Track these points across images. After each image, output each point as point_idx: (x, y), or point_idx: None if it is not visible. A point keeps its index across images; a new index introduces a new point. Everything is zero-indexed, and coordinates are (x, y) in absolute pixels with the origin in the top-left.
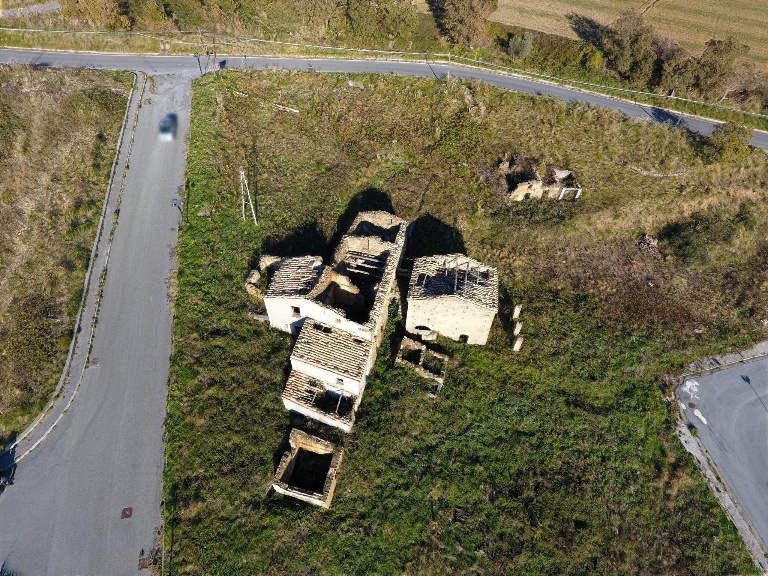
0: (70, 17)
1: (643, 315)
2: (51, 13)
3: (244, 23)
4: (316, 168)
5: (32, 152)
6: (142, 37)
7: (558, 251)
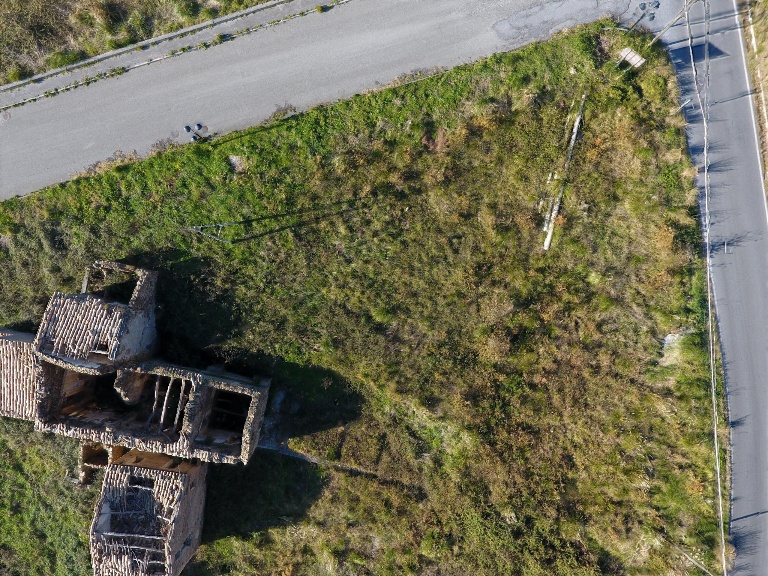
0: None
1: None
2: None
3: None
4: (381, 306)
5: None
6: None
7: None
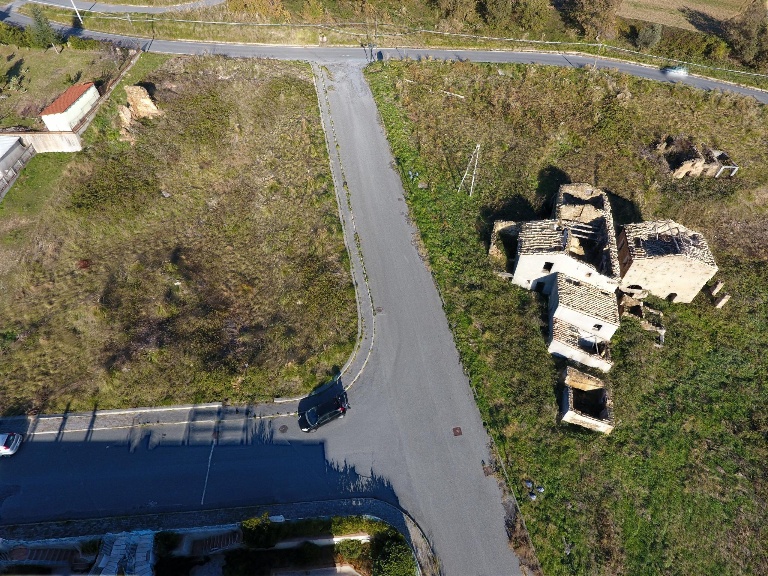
0: (236, 12)
1: None
2: (218, 8)
3: (391, 17)
4: (499, 147)
5: (246, 133)
6: (302, 30)
7: (724, 223)
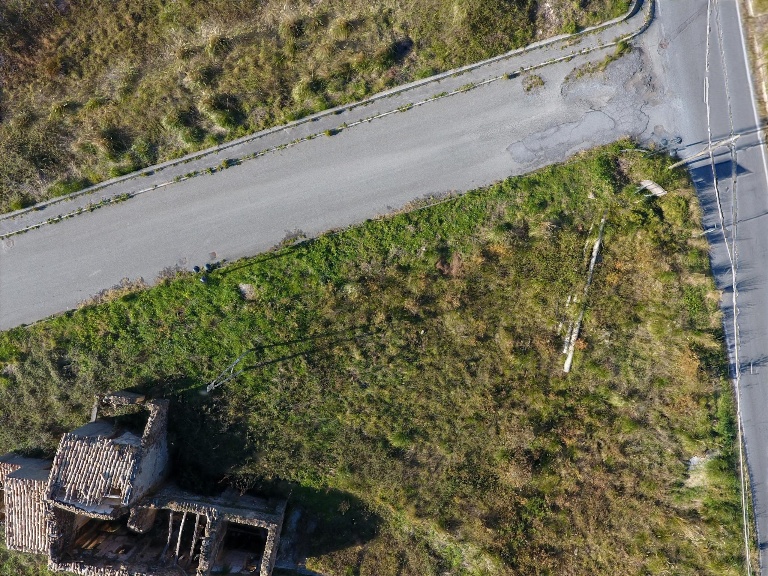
0: None
1: None
2: None
3: None
4: (398, 431)
5: None
6: None
7: None
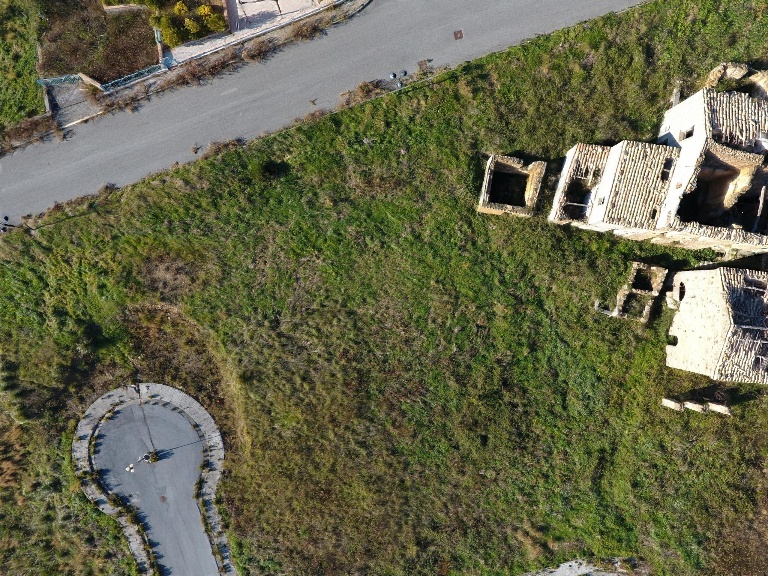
0: None
1: (731, 569)
2: None
3: None
4: None
5: None
6: None
7: None
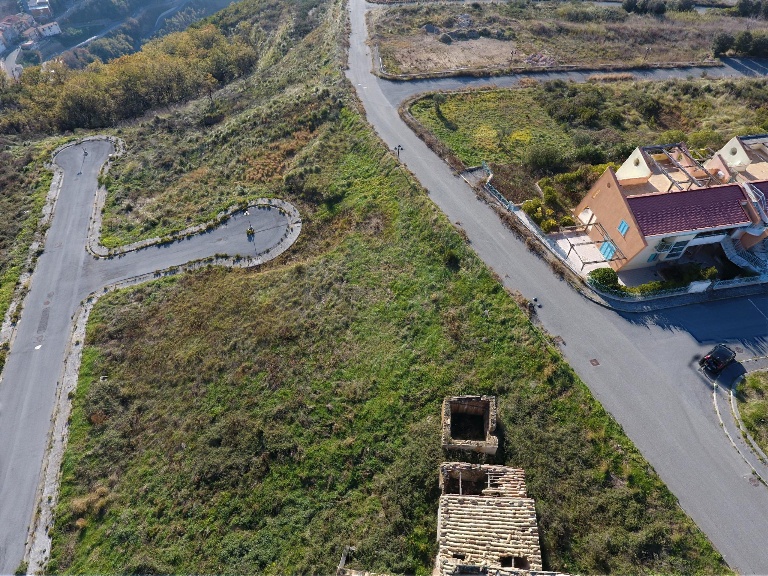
0: None
1: None
2: None
3: None
4: None
5: None
6: None
7: None
